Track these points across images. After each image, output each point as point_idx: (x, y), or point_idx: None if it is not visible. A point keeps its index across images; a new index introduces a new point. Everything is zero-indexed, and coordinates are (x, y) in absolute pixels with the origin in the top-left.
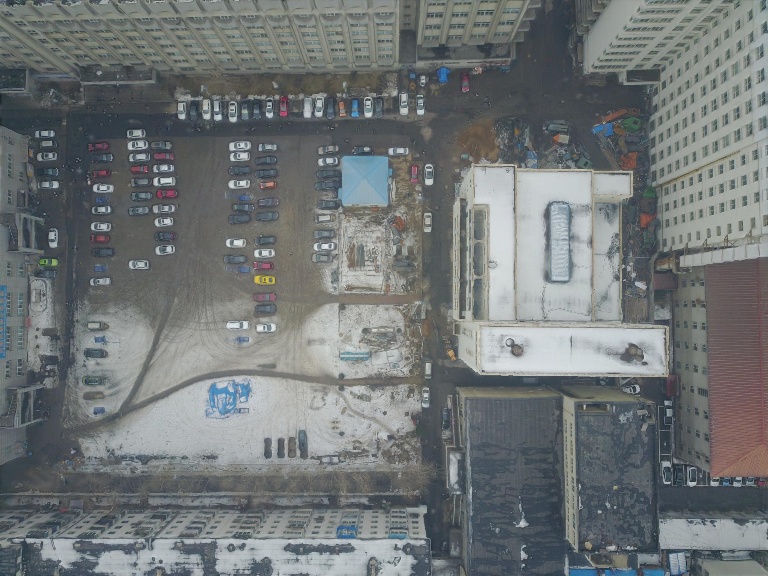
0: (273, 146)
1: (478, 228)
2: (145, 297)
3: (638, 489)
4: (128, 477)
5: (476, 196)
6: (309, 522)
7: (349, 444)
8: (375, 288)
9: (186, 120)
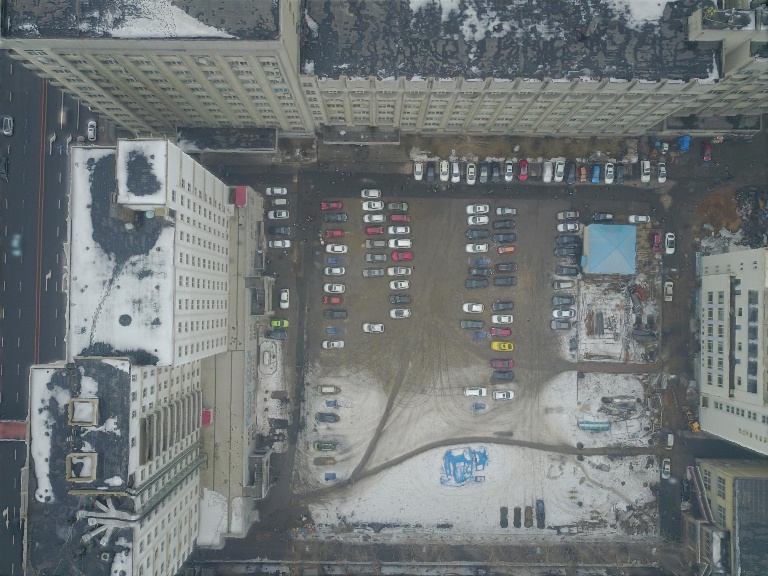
0: (513, 210)
1: None
2: (378, 361)
3: None
4: (360, 545)
5: (766, 279)
6: None
7: (586, 514)
8: (614, 356)
9: (422, 181)
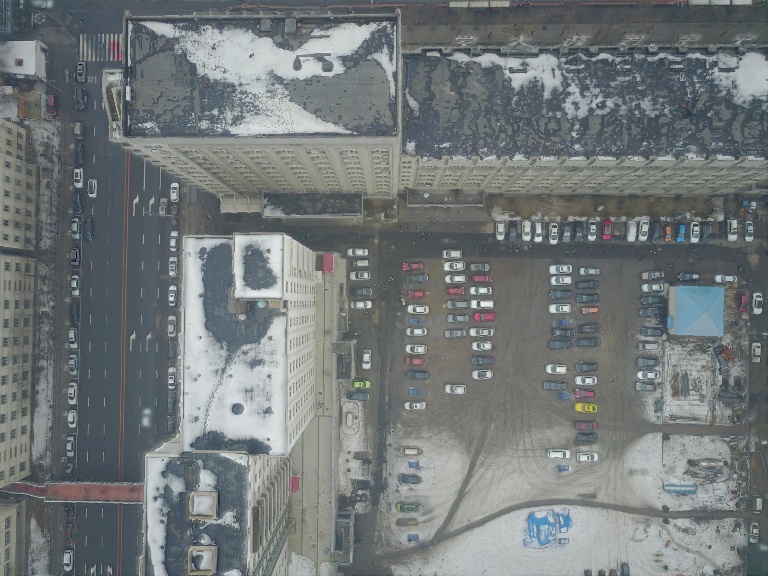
0: (597, 271)
1: None
2: (460, 422)
3: None
4: None
5: None
6: None
7: None
8: (700, 418)
9: (504, 241)
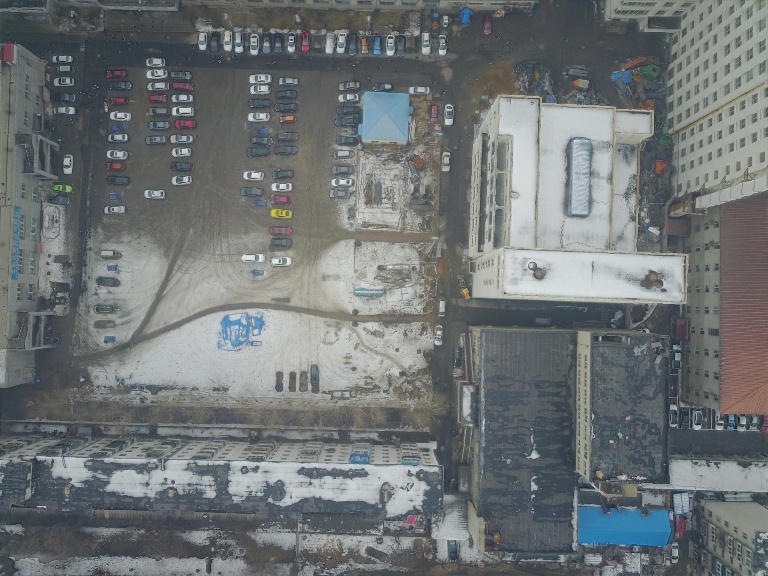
0: (294, 80)
1: (500, 160)
2: (160, 227)
3: (650, 420)
4: (137, 407)
5: (500, 126)
6: (320, 452)
7: (361, 380)
8: (391, 226)
9: (207, 51)
